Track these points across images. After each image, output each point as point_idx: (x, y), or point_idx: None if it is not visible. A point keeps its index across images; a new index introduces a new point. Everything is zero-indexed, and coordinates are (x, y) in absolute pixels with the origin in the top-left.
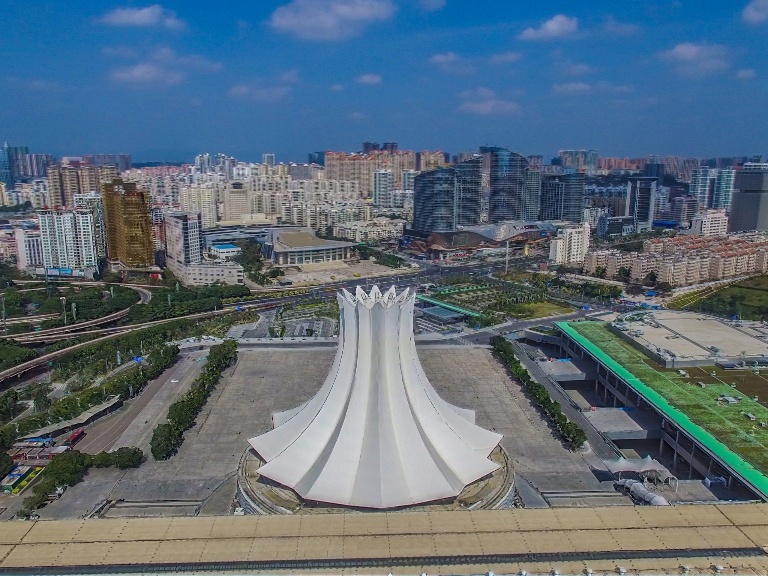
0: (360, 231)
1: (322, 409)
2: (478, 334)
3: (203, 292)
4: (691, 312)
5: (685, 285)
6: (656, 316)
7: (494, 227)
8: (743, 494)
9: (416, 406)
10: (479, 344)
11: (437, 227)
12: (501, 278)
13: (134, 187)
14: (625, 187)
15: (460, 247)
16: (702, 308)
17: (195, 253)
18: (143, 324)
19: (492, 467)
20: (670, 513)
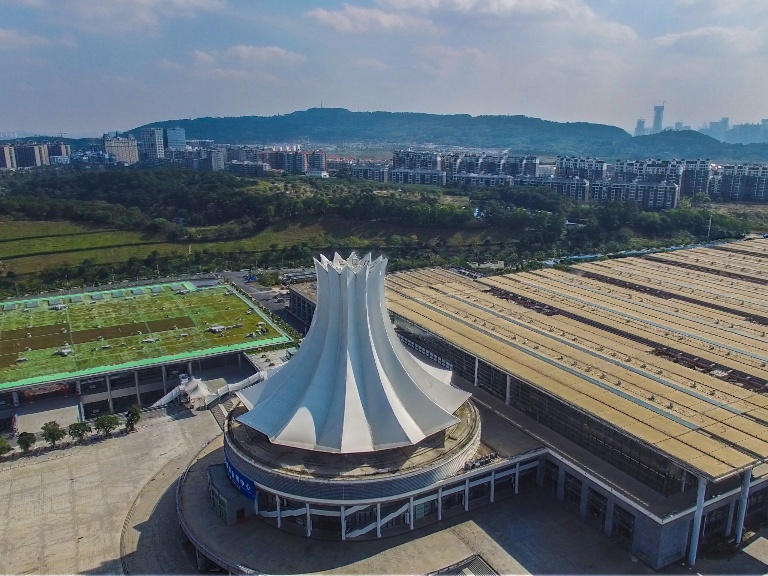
0: None
1: None
2: None
3: None
4: None
5: None
6: None
7: None
8: None
9: None
10: None
11: None
12: None
13: None
14: None
15: None
16: None
17: None
18: None
19: None
20: None
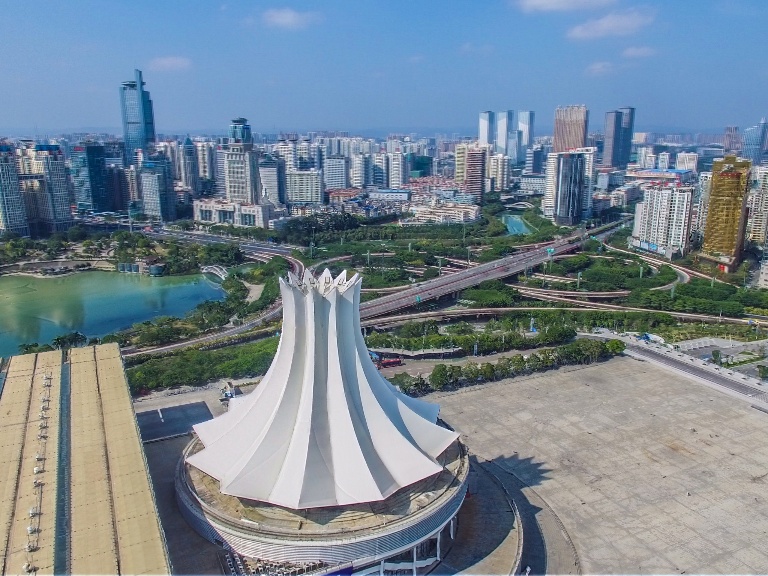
0: None
1: None
2: None
3: (739, 294)
4: None
5: None
6: None
7: None
8: None
9: (303, 405)
10: None
11: None
12: None
13: None
14: None
15: None
16: None
17: None
18: (632, 308)
19: (293, 503)
20: None
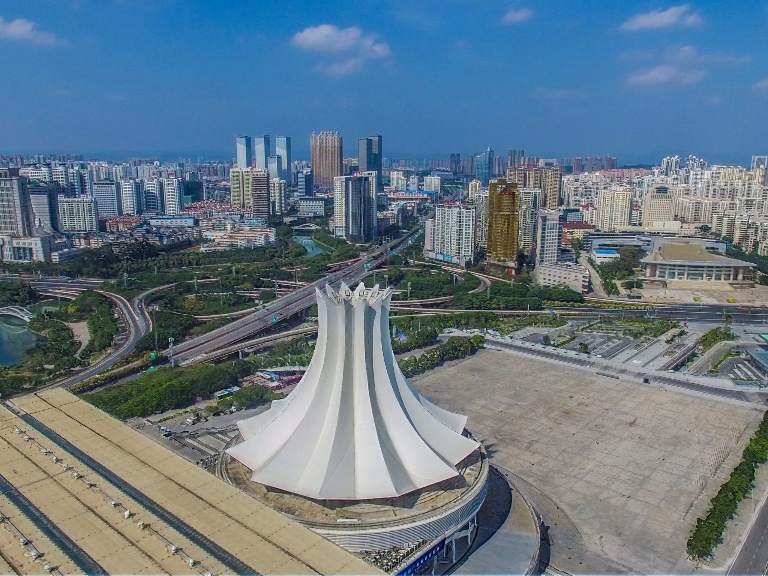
0: None
1: None
2: None
3: (534, 291)
4: None
5: None
6: None
7: None
8: None
9: (358, 408)
10: None
11: None
12: None
13: None
14: None
15: None
16: None
17: (551, 254)
18: (459, 310)
19: (389, 493)
20: None
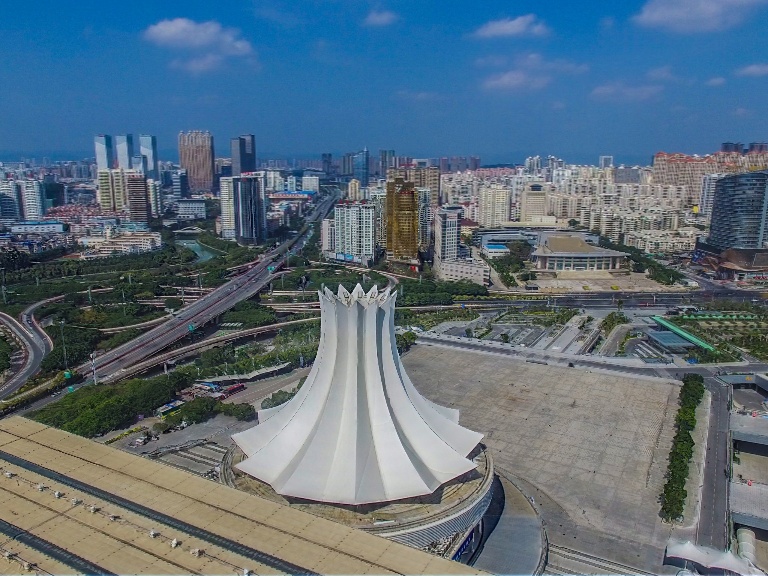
0: (650, 241)
1: (296, 394)
2: (691, 369)
3: (442, 287)
4: None
5: None
6: None
7: None
8: None
9: (373, 410)
10: (679, 380)
11: (734, 242)
12: None
13: (412, 186)
14: None
15: (765, 268)
16: None
17: (451, 250)
18: None
19: (422, 491)
20: None
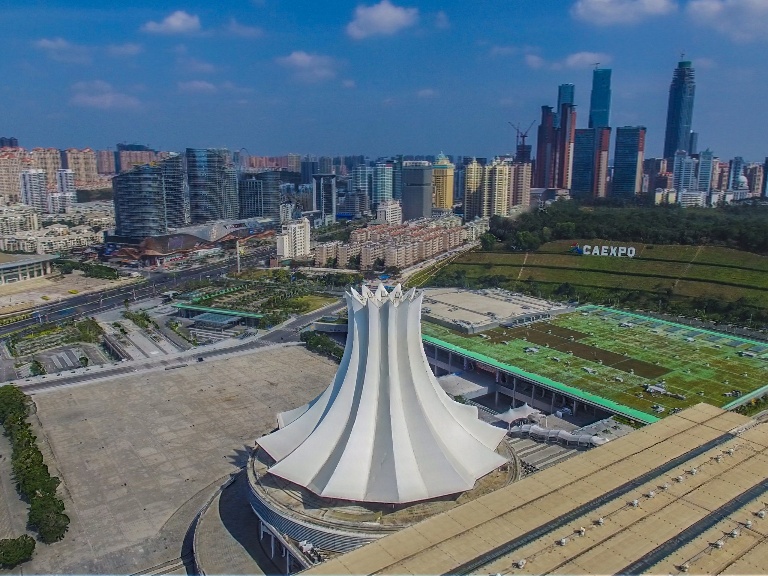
0: (42, 242)
1: (358, 416)
2: (273, 333)
3: None
4: (442, 288)
5: (406, 267)
6: (426, 294)
7: (206, 227)
8: (585, 417)
9: None
10: (284, 342)
11: (150, 231)
12: (238, 278)
13: None
14: (311, 184)
15: (176, 251)
16: (437, 284)
17: None
18: None
19: (503, 432)
20: (662, 427)
